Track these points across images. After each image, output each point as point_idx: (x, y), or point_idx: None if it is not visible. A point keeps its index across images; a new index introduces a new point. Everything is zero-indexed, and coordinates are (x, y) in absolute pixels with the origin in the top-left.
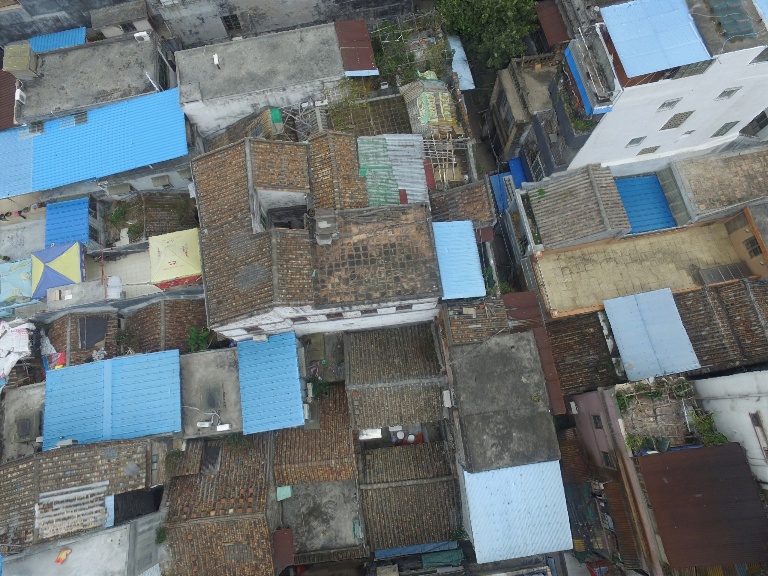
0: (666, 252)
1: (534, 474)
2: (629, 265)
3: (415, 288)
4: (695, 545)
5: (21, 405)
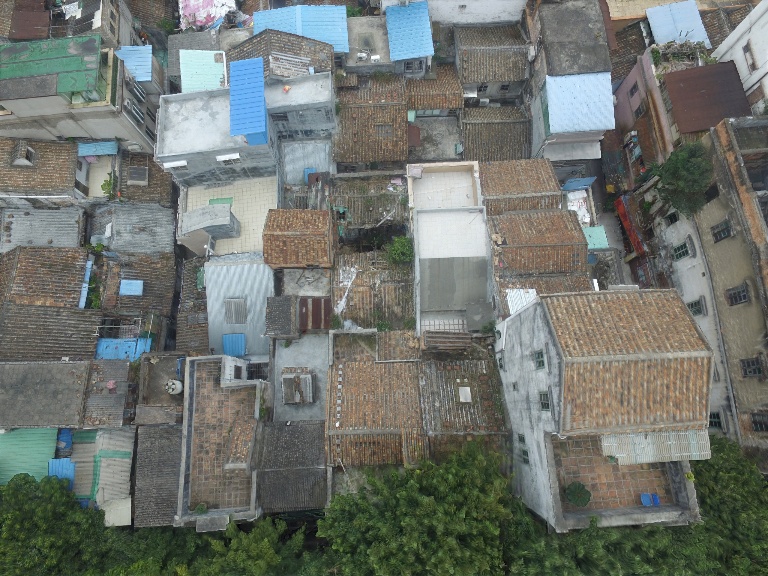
0: None
1: (593, 81)
2: None
3: None
4: (698, 118)
5: (231, 40)
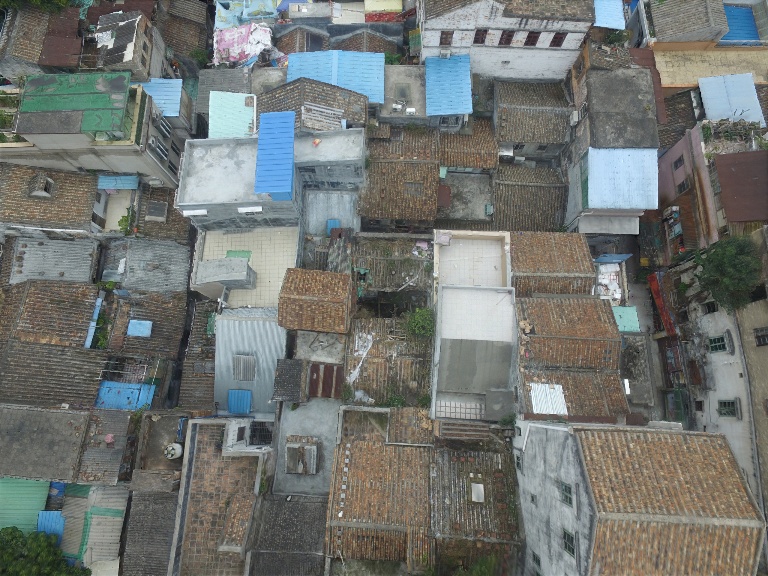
0: (750, 62)
1: (638, 156)
2: (719, 67)
3: (576, 14)
4: (748, 207)
5: (264, 79)
